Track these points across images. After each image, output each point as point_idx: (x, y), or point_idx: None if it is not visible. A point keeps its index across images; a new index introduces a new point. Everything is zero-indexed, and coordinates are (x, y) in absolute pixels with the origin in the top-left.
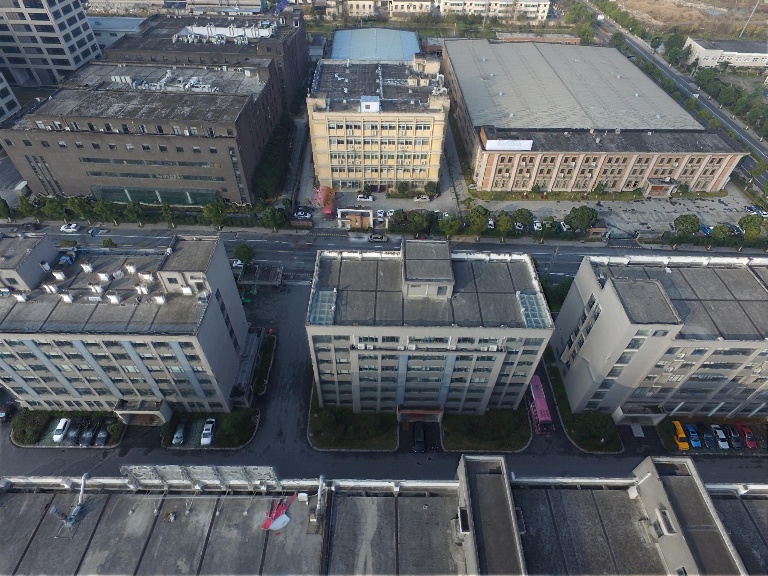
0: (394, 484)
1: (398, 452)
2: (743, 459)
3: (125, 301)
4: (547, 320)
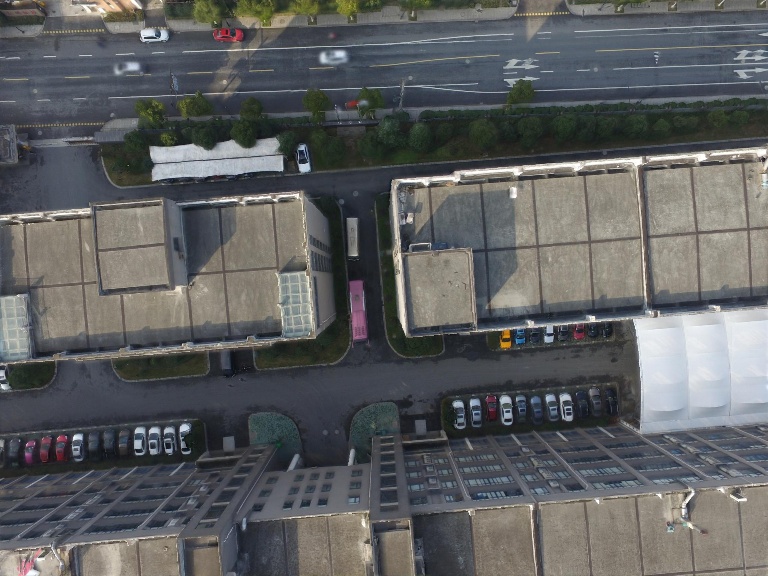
0: (127, 543)
1: (209, 376)
2: (564, 350)
3: None
4: (310, 319)
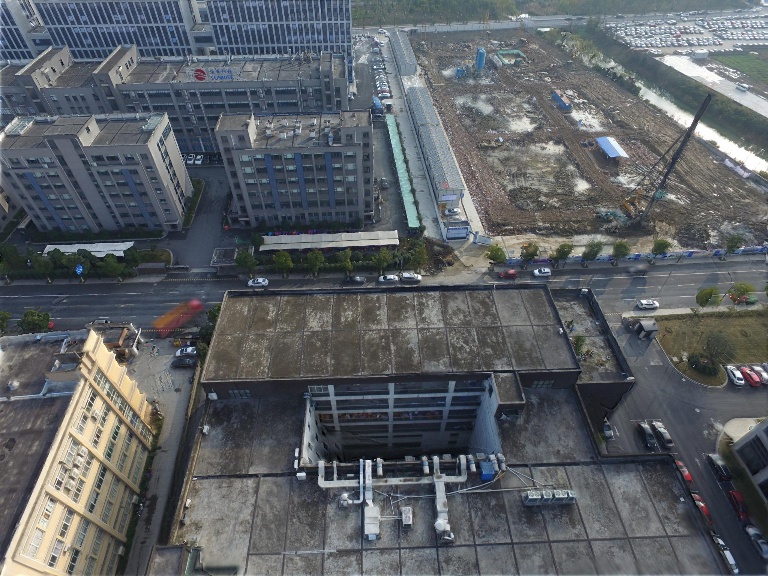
0: None
1: None
2: None
3: (280, 126)
4: None
